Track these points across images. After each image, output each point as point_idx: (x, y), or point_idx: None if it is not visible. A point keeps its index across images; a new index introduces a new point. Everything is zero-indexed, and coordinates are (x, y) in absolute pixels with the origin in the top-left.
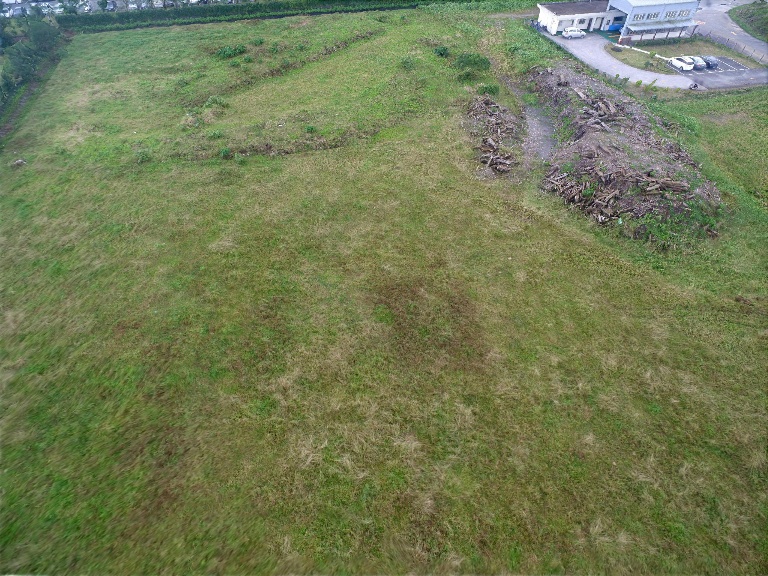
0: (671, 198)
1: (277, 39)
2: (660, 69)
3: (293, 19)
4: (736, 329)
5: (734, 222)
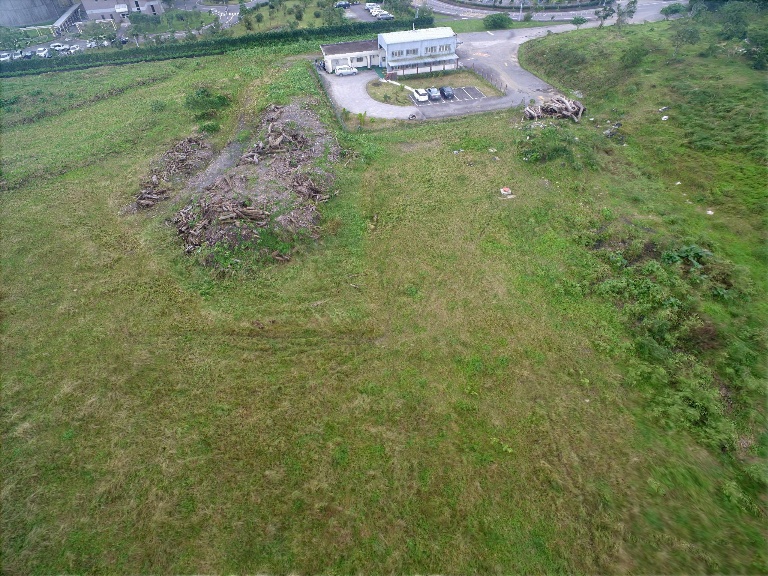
0: (240, 226)
1: (59, 89)
2: (399, 101)
3: (95, 69)
4: (225, 352)
5: (312, 247)
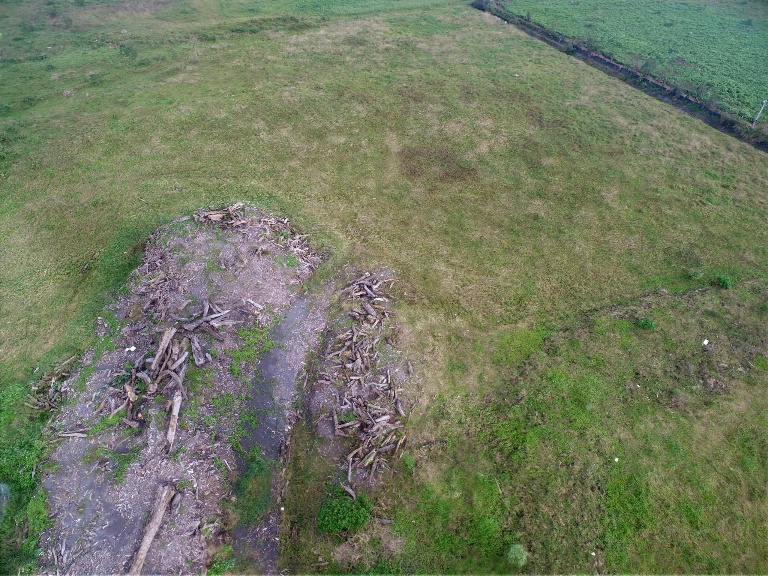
0: None
1: None
2: None
3: None
4: None
5: None
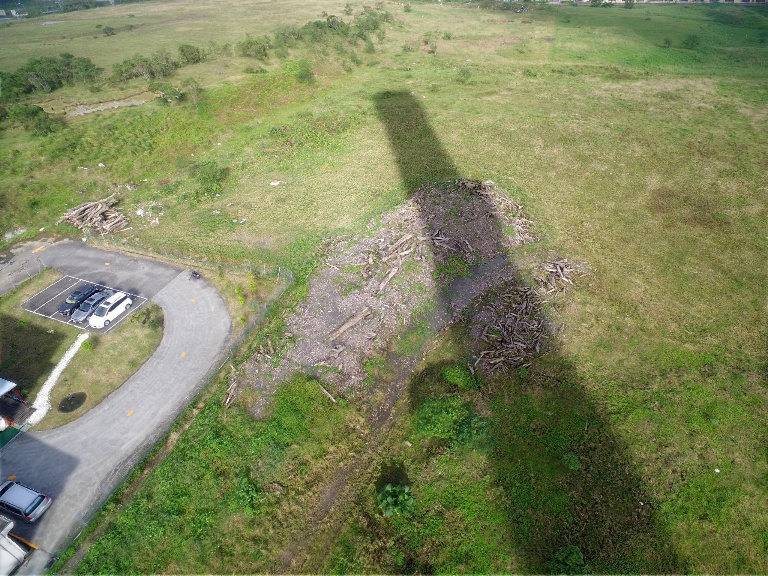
0: None
1: None
2: (144, 321)
3: None
4: None
5: None
